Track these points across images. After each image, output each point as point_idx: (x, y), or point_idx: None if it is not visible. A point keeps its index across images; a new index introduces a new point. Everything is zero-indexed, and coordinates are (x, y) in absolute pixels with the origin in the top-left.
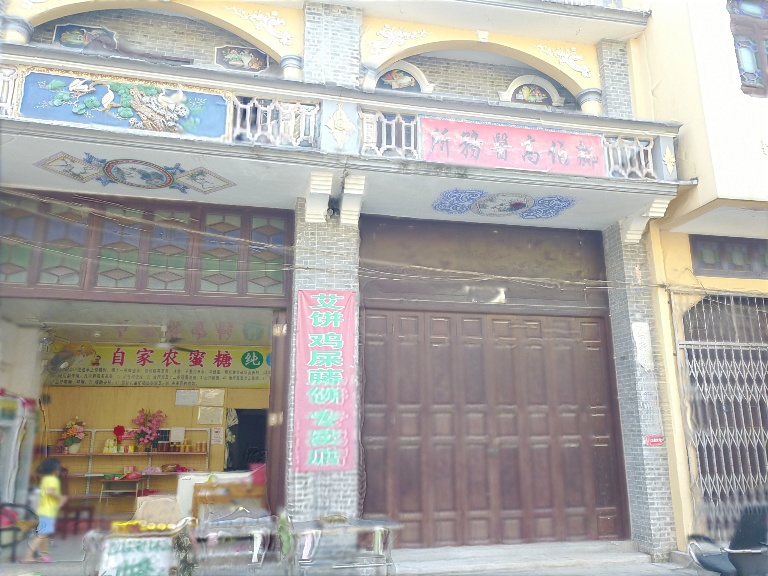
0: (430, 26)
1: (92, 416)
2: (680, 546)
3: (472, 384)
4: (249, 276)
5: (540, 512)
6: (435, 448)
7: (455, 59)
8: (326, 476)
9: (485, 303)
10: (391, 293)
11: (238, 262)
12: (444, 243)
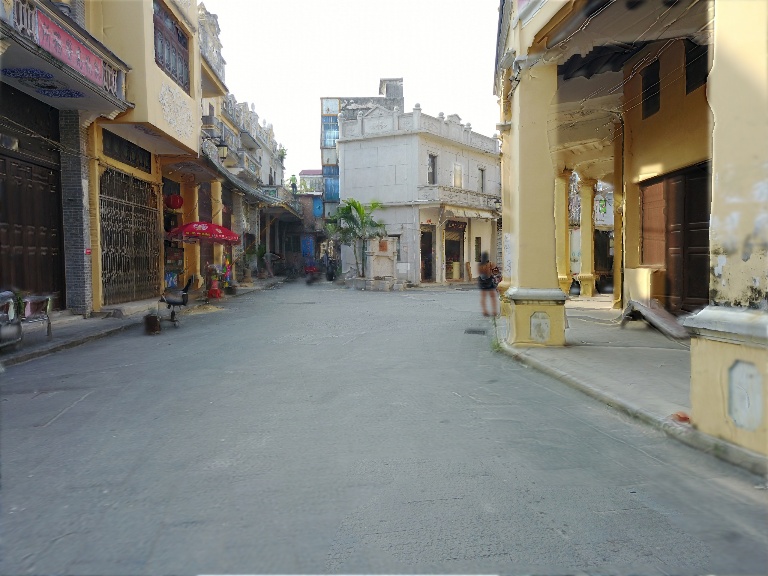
0: None
1: None
2: (96, 309)
3: (1, 208)
4: None
5: None
6: None
7: None
8: None
9: None
10: None
11: None
12: None
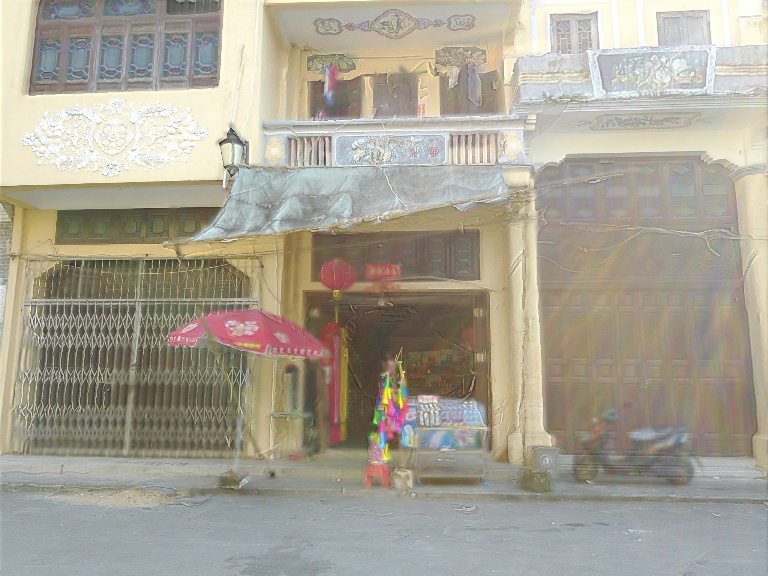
0: None
1: None
2: None
3: None
4: None
5: None
6: None
7: None
8: None
9: None
10: None
11: None
12: None
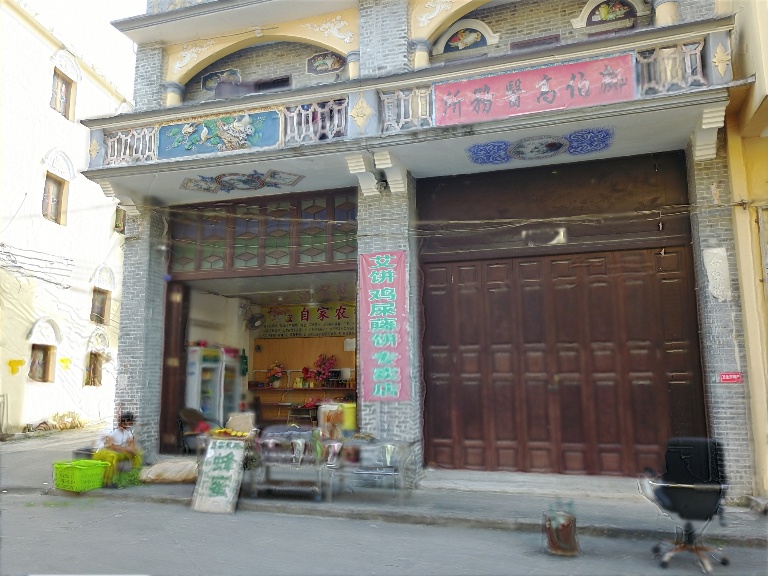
0: None
1: (287, 360)
2: (754, 491)
3: (529, 324)
4: (334, 246)
5: (601, 447)
6: (493, 384)
7: None
8: (385, 405)
9: (540, 246)
10: (447, 247)
11: (325, 236)
12: (500, 192)
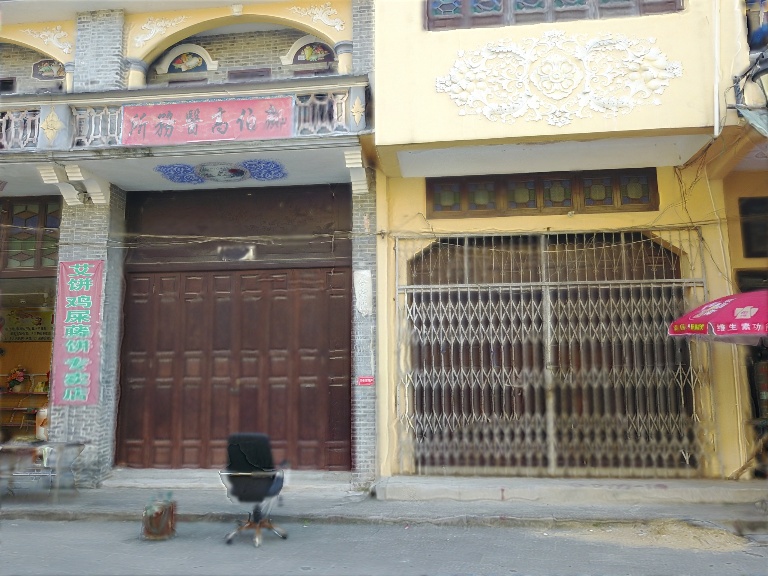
0: (189, 10)
1: (32, 364)
2: None
3: (219, 333)
4: (43, 253)
5: (272, 443)
6: (183, 388)
7: (241, 32)
8: (73, 409)
9: (232, 261)
10: (149, 258)
11: (35, 242)
12: (202, 210)
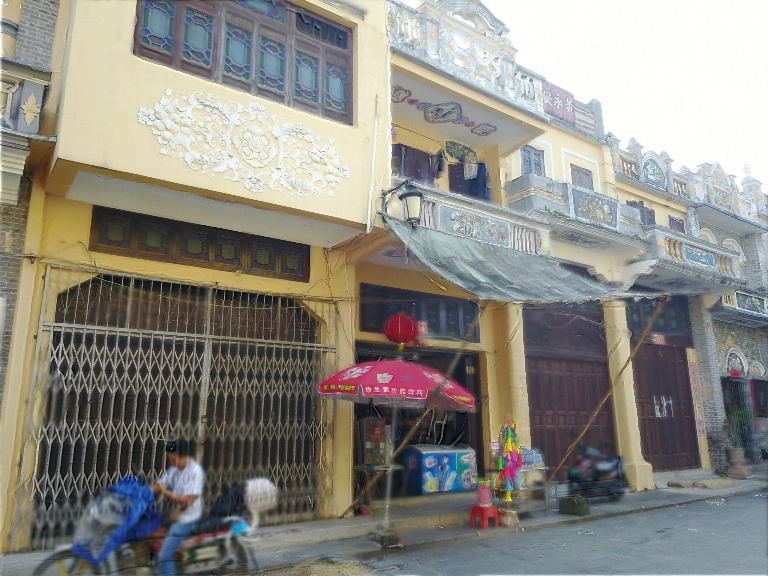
0: None
1: None
2: None
3: None
4: None
5: None
6: None
7: None
8: None
9: None
10: None
11: None
12: None
